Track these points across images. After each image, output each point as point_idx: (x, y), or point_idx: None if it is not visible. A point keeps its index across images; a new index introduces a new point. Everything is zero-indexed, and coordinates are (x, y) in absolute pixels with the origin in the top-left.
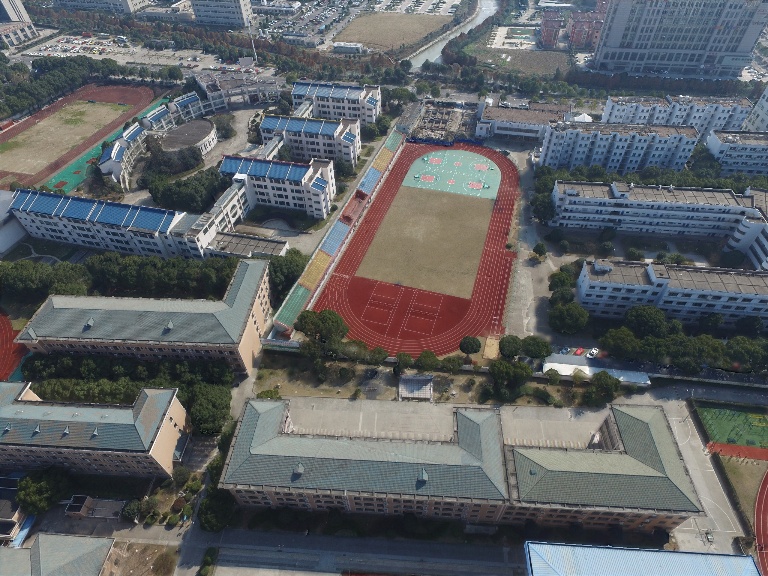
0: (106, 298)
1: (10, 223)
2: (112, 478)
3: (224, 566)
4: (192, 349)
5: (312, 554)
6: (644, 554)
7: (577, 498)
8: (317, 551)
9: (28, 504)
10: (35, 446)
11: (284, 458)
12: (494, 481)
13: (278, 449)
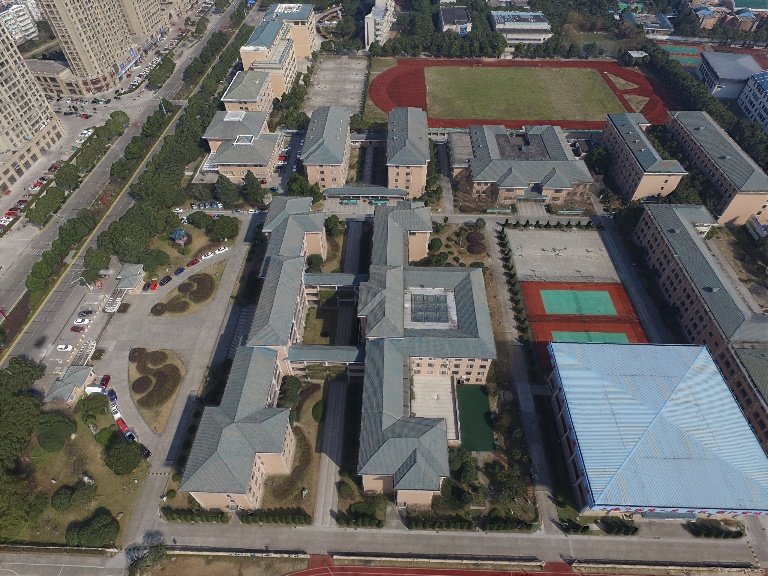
0: (723, 130)
1: (739, 85)
2: (615, 183)
3: (599, 234)
4: (718, 177)
5: (624, 269)
6: (744, 421)
7: (762, 385)
8: (627, 271)
9: (592, 154)
10: (622, 137)
11: (680, 222)
12: (739, 331)
13: (683, 220)
